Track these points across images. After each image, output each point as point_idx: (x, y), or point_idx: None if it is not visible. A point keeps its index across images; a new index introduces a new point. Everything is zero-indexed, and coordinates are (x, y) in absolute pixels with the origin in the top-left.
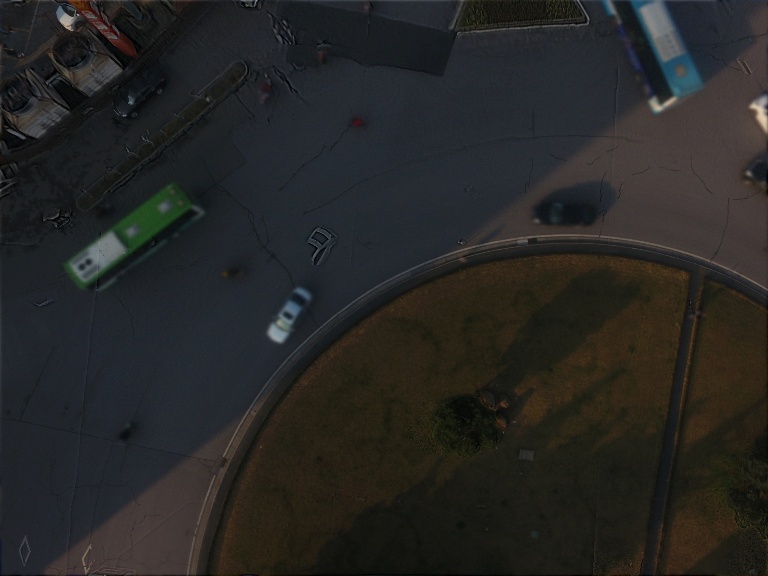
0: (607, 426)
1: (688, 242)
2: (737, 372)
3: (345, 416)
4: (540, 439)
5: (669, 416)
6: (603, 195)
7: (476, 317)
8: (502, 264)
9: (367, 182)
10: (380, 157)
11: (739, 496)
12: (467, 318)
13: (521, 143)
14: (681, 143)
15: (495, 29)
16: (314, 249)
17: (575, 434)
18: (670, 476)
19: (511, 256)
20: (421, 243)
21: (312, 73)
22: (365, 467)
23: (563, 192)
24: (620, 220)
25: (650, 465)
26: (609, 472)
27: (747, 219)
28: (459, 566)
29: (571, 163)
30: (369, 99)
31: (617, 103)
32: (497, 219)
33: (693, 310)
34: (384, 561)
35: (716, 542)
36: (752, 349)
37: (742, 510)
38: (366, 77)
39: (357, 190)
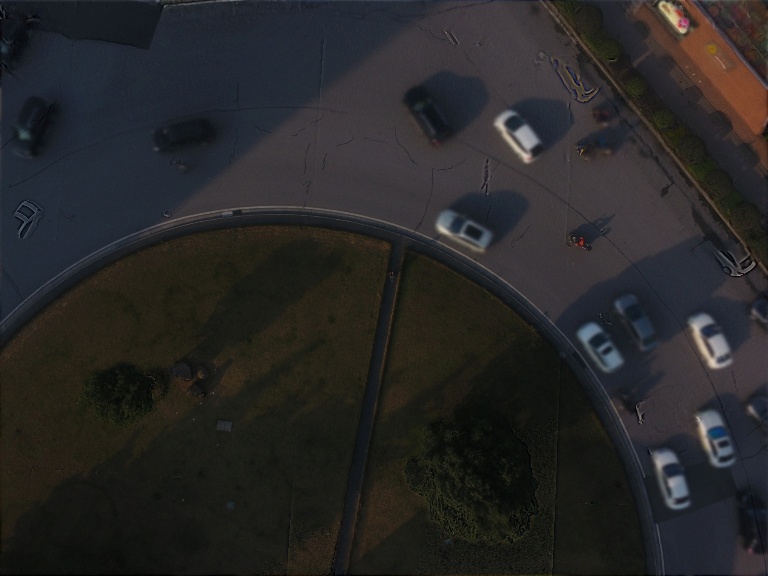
0: (305, 396)
1: (392, 213)
2: (437, 342)
3: (45, 388)
4: (237, 410)
5: (368, 386)
6: (307, 166)
7: (177, 289)
8: (205, 236)
9: (74, 155)
10: (86, 130)
11: (412, 463)
12: (168, 290)
13: (226, 115)
14: (386, 114)
15: (202, 2)
16: (20, 223)
17: (272, 405)
18: (368, 446)
19: (213, 228)
20: (127, 216)
21: (22, 47)
22: (63, 439)
23: (268, 164)
24: (324, 191)
25: (348, 435)
26: (306, 442)
27: (451, 189)
28: (155, 537)
29: (276, 135)
30: (77, 73)
31: (323, 74)
32: (201, 191)
33: (395, 280)
34: (80, 532)
35: (412, 511)
36: (453, 319)
37: (409, 477)
38: (74, 51)
39: (64, 164)
